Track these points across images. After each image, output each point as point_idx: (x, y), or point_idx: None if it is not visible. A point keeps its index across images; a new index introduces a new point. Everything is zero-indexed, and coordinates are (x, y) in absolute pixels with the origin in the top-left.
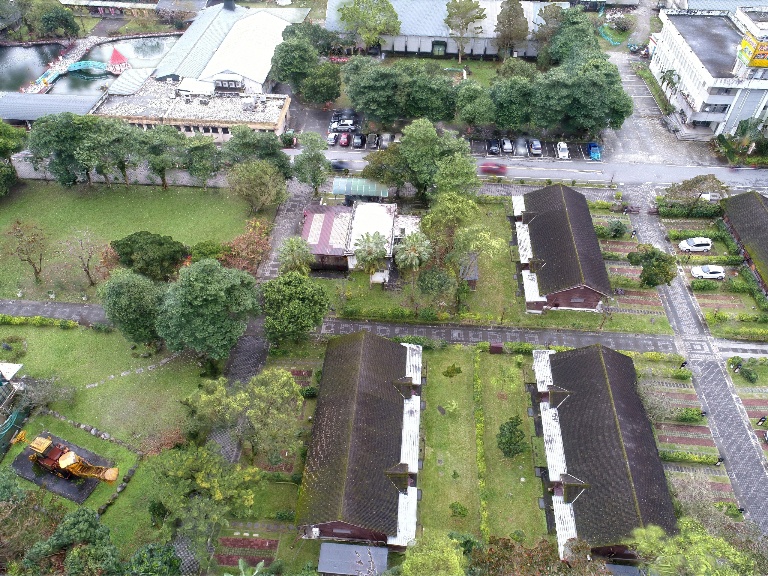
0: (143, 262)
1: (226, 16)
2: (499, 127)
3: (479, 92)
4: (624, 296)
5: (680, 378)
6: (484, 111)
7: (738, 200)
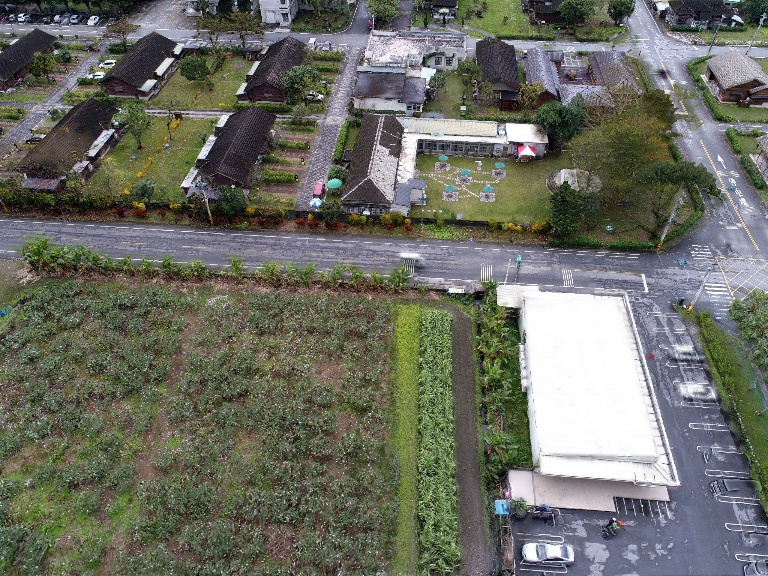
0: None
1: None
2: (48, 4)
3: None
4: (33, 87)
5: (14, 118)
6: None
7: None
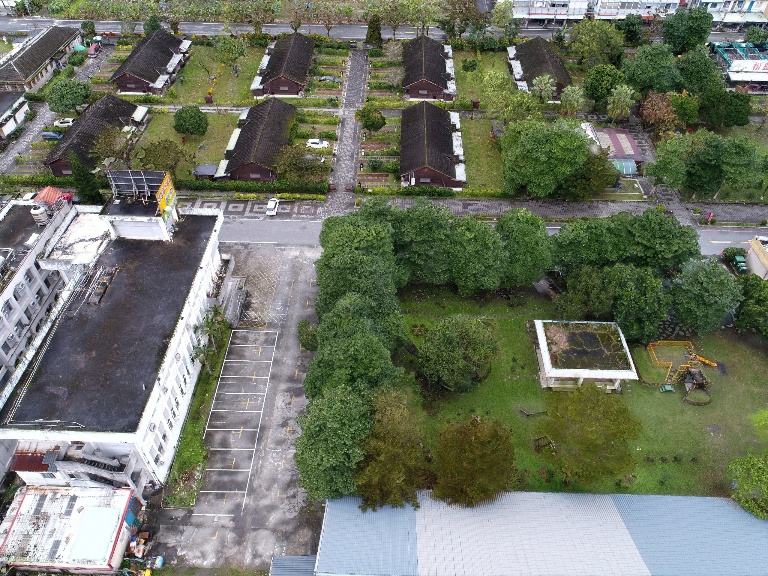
0: None
1: None
2: None
3: None
4: None
5: None
6: None
7: (267, 162)
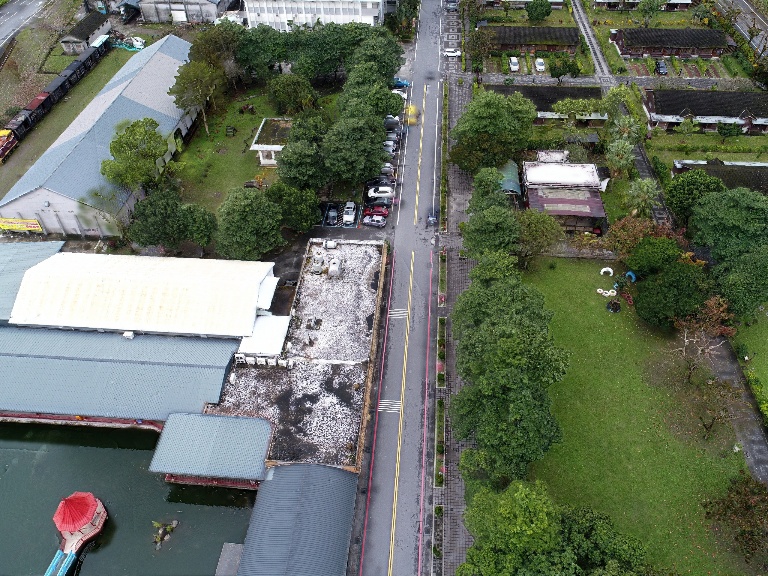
0: None
1: None
2: None
3: None
4: None
5: None
6: None
7: None
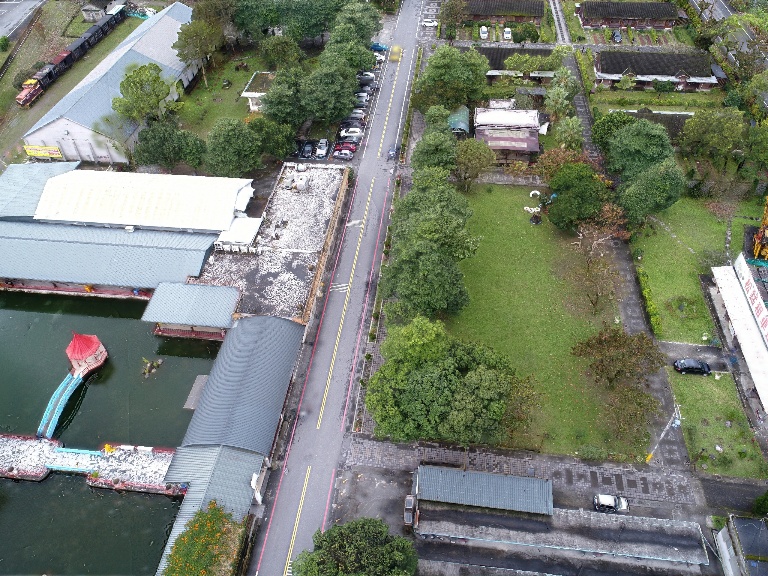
0: None
1: (0, 231)
2: None
3: None
4: None
5: None
6: None
7: None
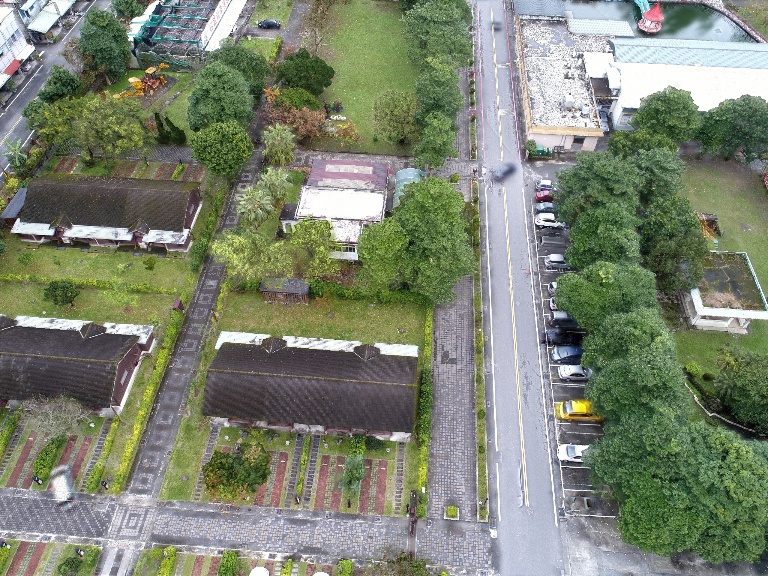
0: (279, 66)
1: None
2: None
3: (605, 282)
4: None
5: None
6: (566, 294)
7: None
